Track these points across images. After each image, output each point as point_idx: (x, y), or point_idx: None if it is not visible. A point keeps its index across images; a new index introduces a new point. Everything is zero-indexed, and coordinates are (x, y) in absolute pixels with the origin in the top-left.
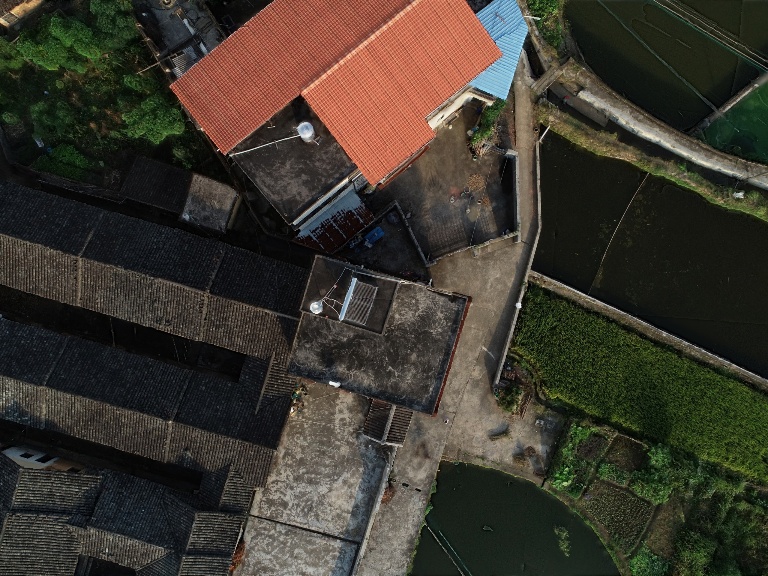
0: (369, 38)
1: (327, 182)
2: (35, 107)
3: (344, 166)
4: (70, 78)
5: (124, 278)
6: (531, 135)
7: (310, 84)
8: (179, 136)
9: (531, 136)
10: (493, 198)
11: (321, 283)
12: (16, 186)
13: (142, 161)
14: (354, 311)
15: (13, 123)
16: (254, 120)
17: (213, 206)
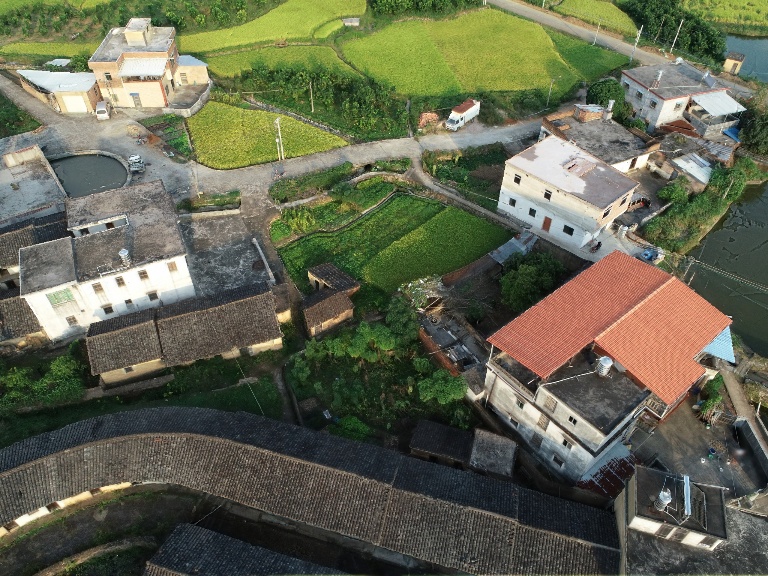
0: (634, 308)
1: (628, 404)
2: (338, 382)
3: (638, 393)
4: (360, 367)
5: (432, 509)
6: (748, 408)
7: (600, 334)
8: (450, 408)
9: (749, 409)
10: (739, 459)
11: (648, 490)
12: (324, 434)
13: (424, 423)
14: (694, 511)
15: (318, 393)
16: (562, 356)
17: (497, 455)
